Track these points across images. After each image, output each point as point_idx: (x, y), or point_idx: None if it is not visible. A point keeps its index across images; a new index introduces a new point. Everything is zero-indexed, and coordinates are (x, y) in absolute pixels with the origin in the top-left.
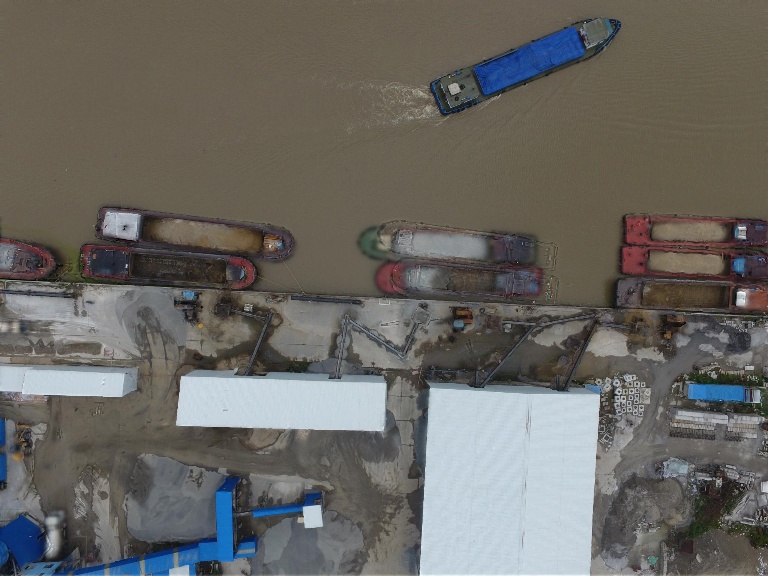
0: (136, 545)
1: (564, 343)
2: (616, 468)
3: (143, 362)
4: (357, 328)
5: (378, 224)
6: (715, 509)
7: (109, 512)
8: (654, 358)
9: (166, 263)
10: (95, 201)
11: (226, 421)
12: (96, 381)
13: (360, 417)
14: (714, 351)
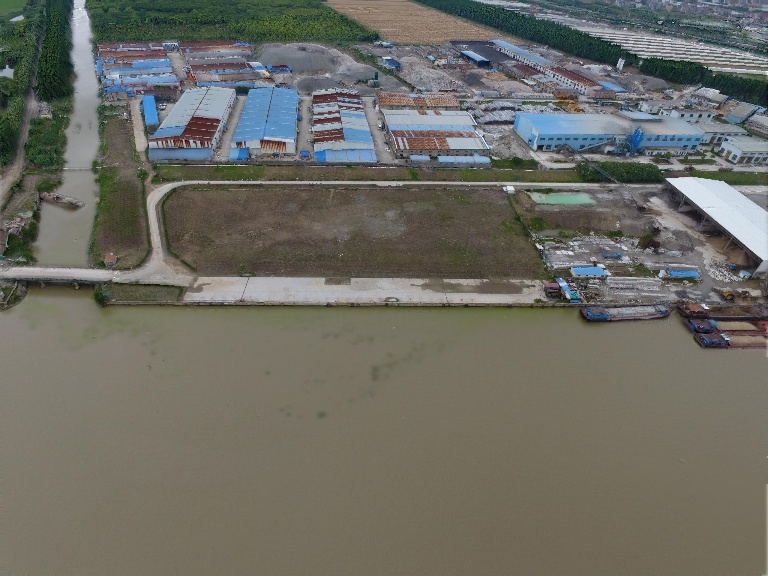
0: None
1: None
2: None
3: None
4: None
5: None
6: None
7: None
8: (721, 288)
9: None
10: None
11: None
12: None
13: None
14: (692, 291)
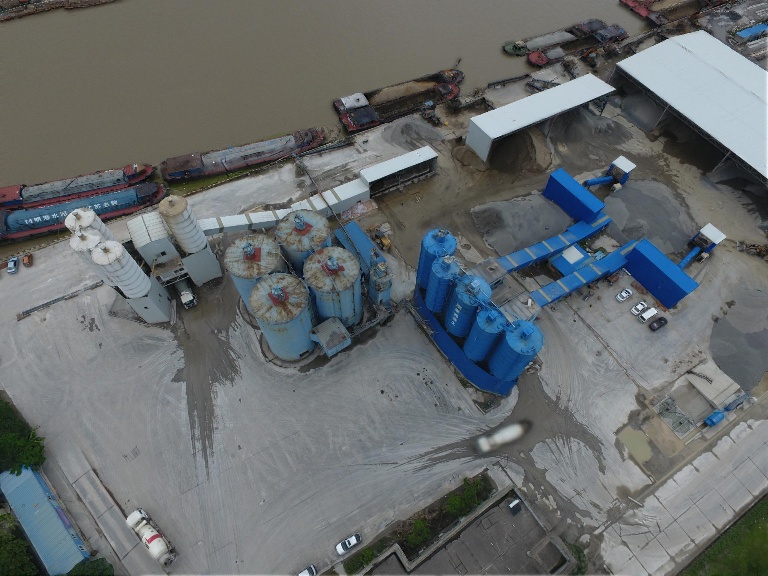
0: (521, 268)
1: None
2: None
3: None
4: None
5: (500, 47)
6: None
7: (481, 256)
8: None
9: (394, 113)
10: (326, 104)
11: (520, 124)
12: (413, 156)
13: (595, 91)
14: (727, 23)
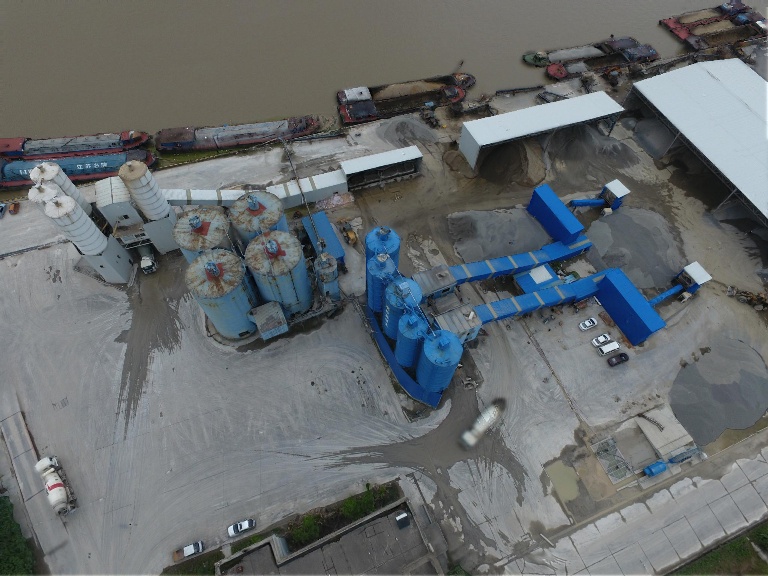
0: (485, 281)
1: None
2: None
3: None
4: None
5: (520, 56)
6: None
7: (446, 263)
8: None
9: (396, 110)
10: (330, 94)
11: (513, 134)
12: (397, 154)
13: (602, 109)
14: None
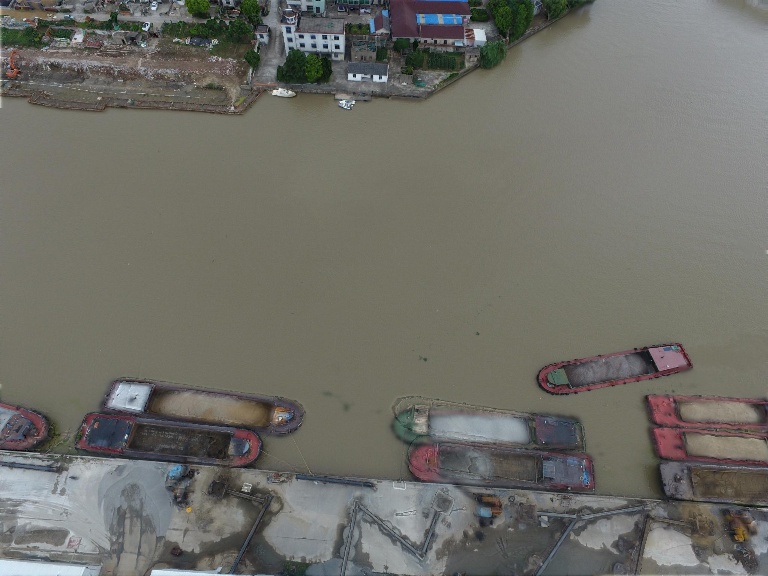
0: None
1: (616, 545)
2: None
3: (110, 558)
4: (368, 518)
5: (393, 399)
6: None
7: None
8: (732, 569)
9: (168, 436)
10: (115, 372)
11: None
12: None
13: None
14: None
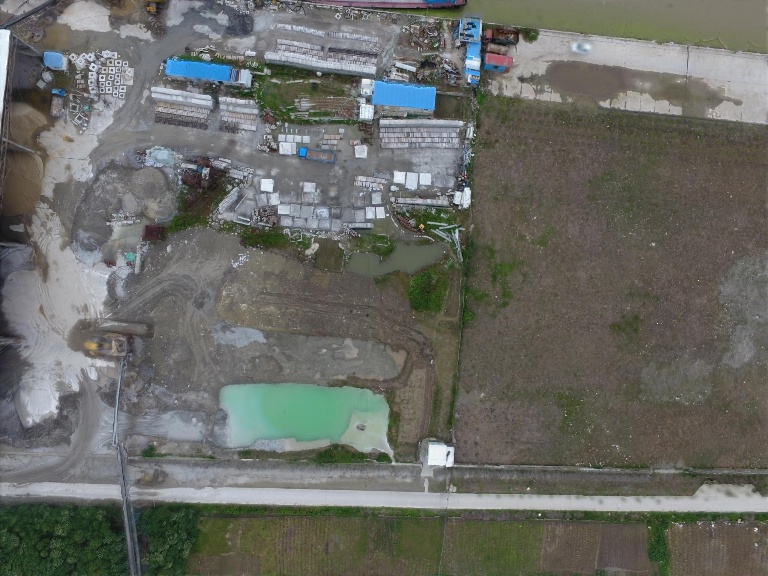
0: None
1: None
2: (92, 153)
3: None
4: None
5: None
6: (202, 203)
7: None
8: (140, 36)
9: None
10: None
11: None
12: None
13: None
14: (211, 33)
